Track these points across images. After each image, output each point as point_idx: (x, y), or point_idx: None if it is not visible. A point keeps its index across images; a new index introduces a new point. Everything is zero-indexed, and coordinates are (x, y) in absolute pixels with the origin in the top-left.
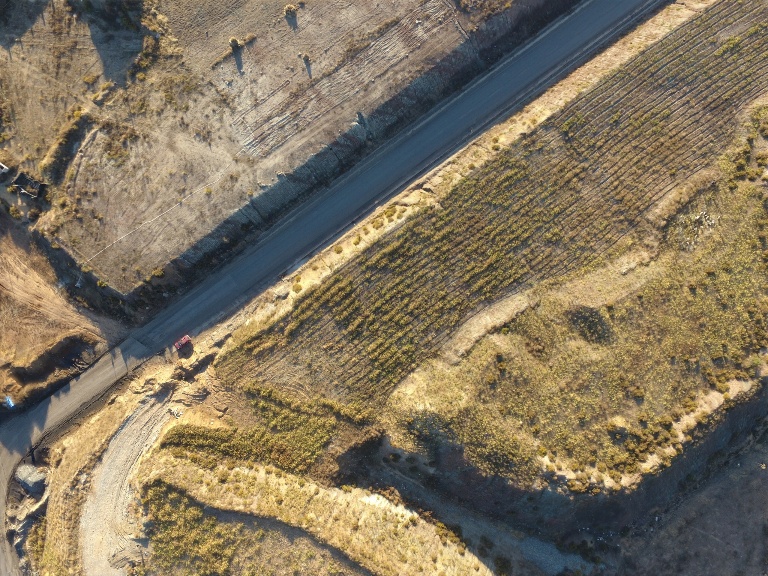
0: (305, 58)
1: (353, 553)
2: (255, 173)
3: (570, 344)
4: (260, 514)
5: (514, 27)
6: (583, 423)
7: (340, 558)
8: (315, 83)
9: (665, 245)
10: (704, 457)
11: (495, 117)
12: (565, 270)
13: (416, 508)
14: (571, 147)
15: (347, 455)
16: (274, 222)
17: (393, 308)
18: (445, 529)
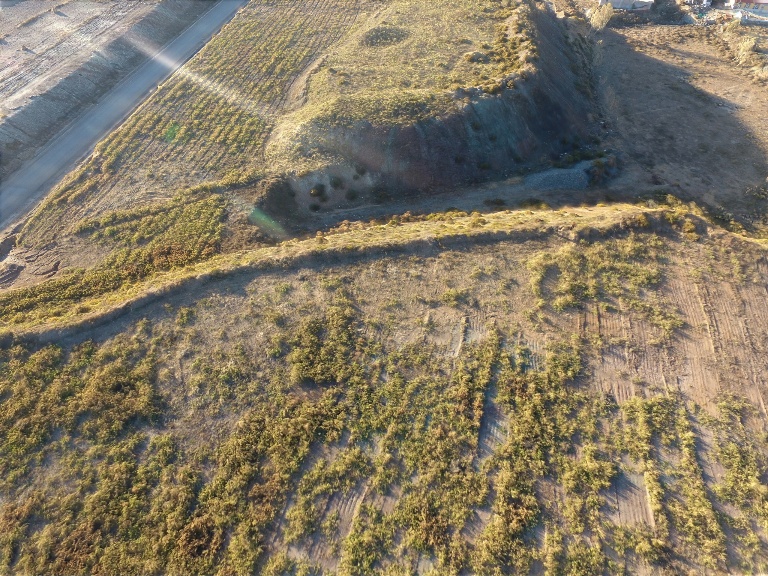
0: (24, 48)
1: (338, 245)
2: (3, 106)
3: (382, 50)
4: (165, 287)
5: (193, 4)
6: (446, 67)
7: (328, 265)
8: (41, 55)
9: (386, 3)
10: (565, 66)
11: (216, 33)
12: (337, 39)
13: (388, 218)
14: (277, 6)
15: (259, 216)
16: (48, 138)
17: (213, 110)
18: (439, 214)
